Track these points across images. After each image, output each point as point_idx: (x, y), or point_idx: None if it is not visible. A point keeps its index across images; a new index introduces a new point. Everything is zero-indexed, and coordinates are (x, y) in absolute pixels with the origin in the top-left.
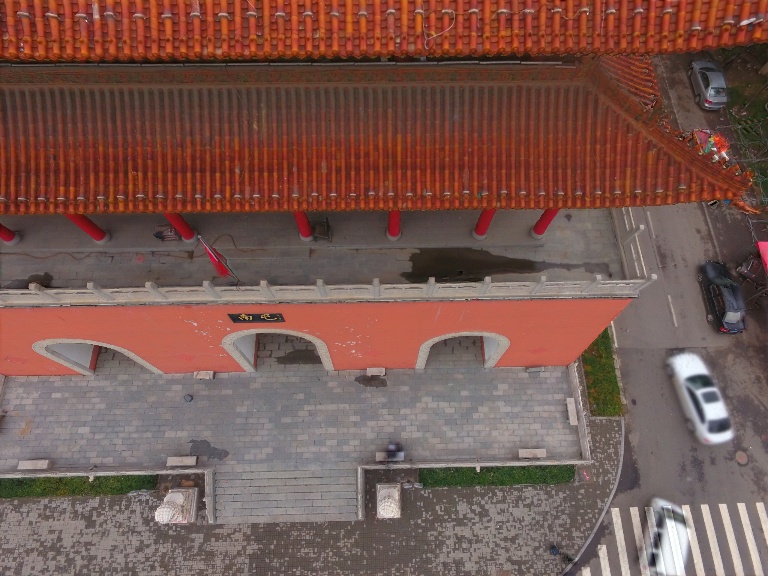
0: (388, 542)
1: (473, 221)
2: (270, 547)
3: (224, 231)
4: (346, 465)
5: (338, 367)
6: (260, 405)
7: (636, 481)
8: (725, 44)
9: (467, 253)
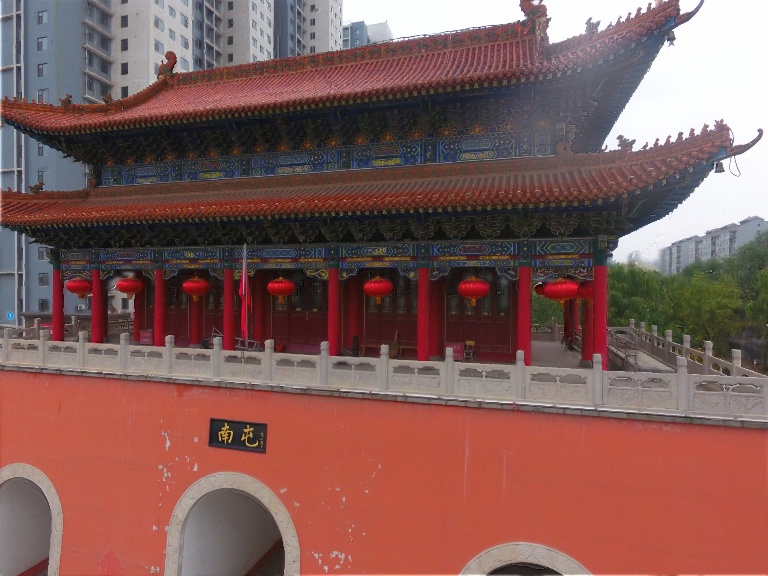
0: None
1: None
2: None
3: None
4: None
5: None
6: None
7: None
8: (611, 45)
9: None
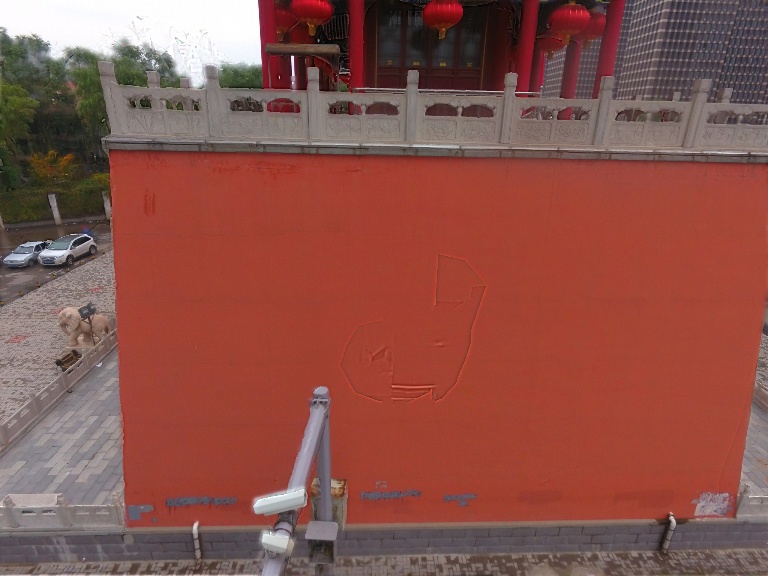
0: None
1: None
2: None
3: None
4: None
5: None
6: None
7: None
8: None
9: None
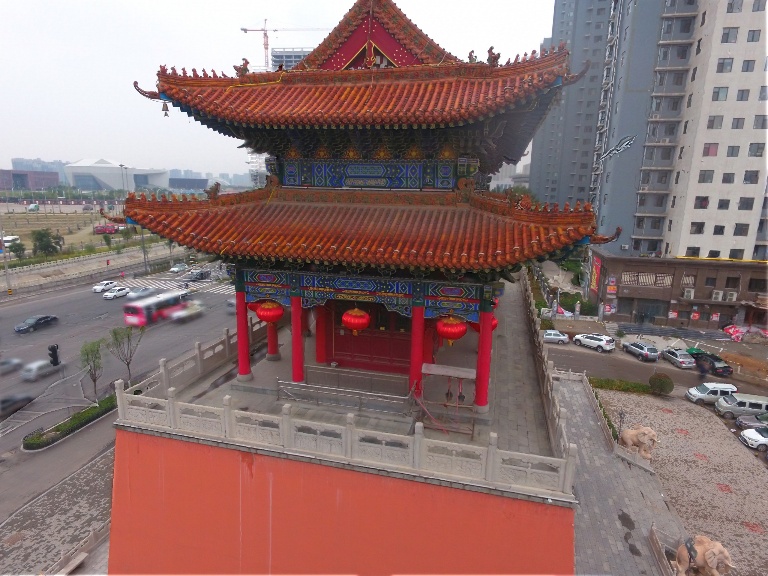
0: None
1: (287, 358)
2: None
3: None
4: None
5: None
6: None
7: None
8: None
9: None
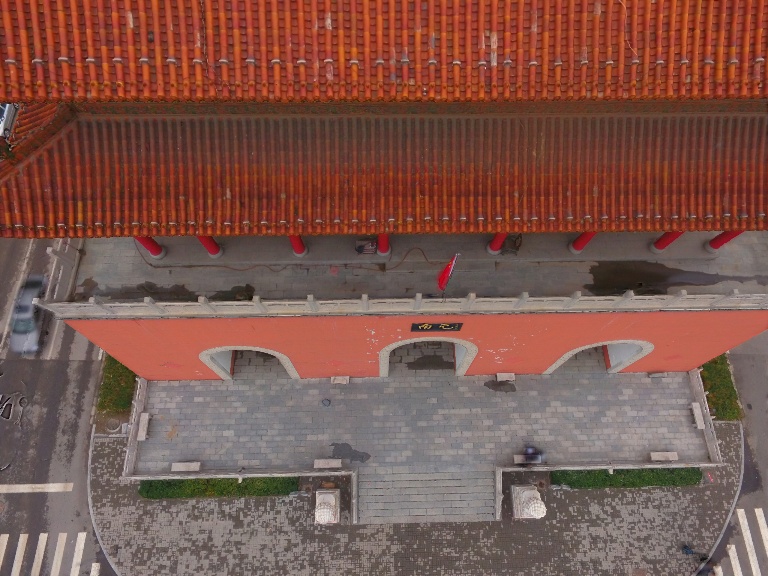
0: (526, 542)
1: (648, 235)
2: (413, 546)
3: (414, 245)
4: (484, 467)
5: (469, 372)
6: (395, 409)
7: (758, 483)
8: None
9: (643, 266)
